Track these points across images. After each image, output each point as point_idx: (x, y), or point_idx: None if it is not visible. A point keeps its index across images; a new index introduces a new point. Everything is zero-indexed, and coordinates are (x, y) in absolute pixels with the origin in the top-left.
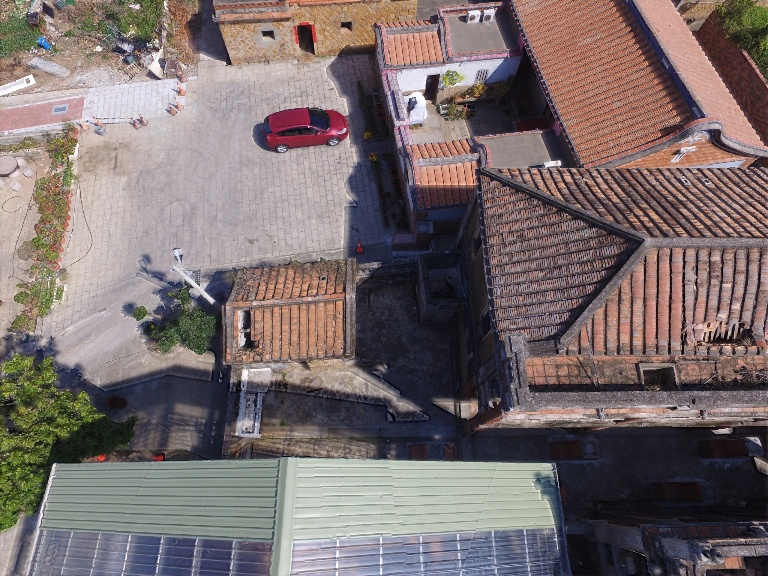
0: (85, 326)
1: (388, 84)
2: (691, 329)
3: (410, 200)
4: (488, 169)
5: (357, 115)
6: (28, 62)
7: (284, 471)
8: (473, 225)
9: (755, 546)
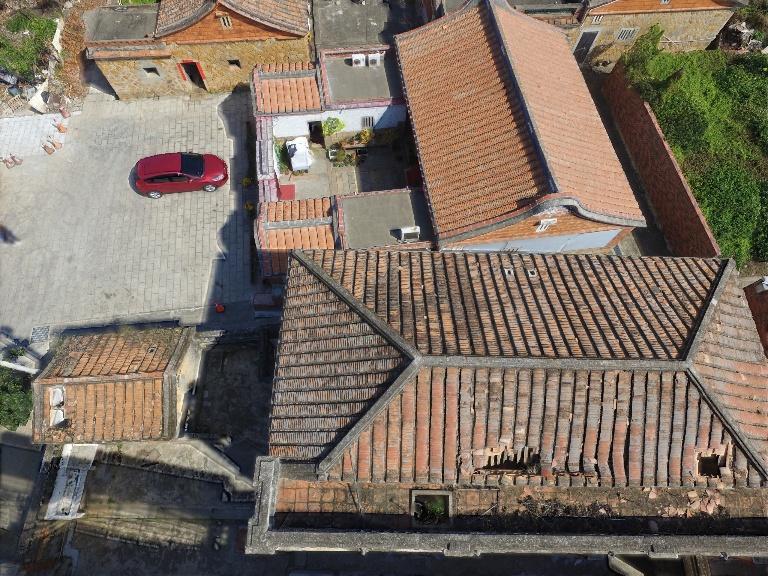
0: None
1: (261, 132)
2: (469, 455)
3: None
4: (298, 252)
5: (242, 158)
6: None
7: None
8: None
9: None
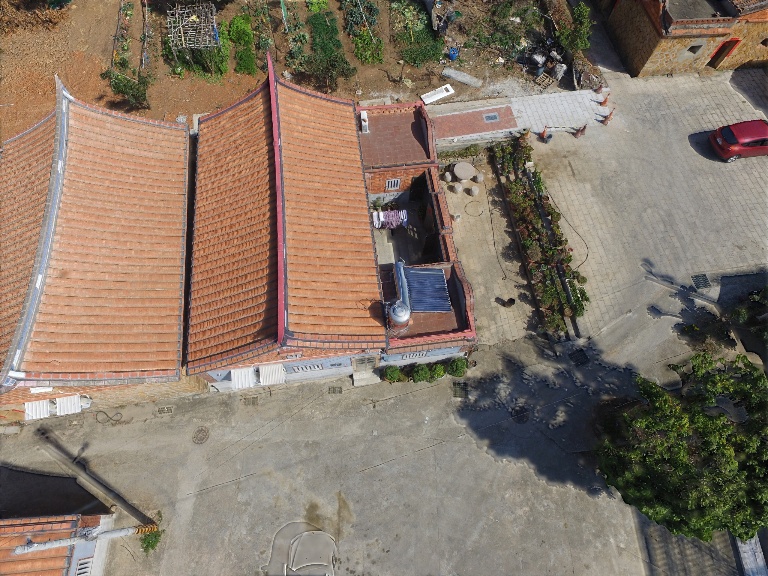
0: (618, 327)
1: None
2: None
3: None
4: None
5: None
6: (441, 72)
7: None
8: None
9: None
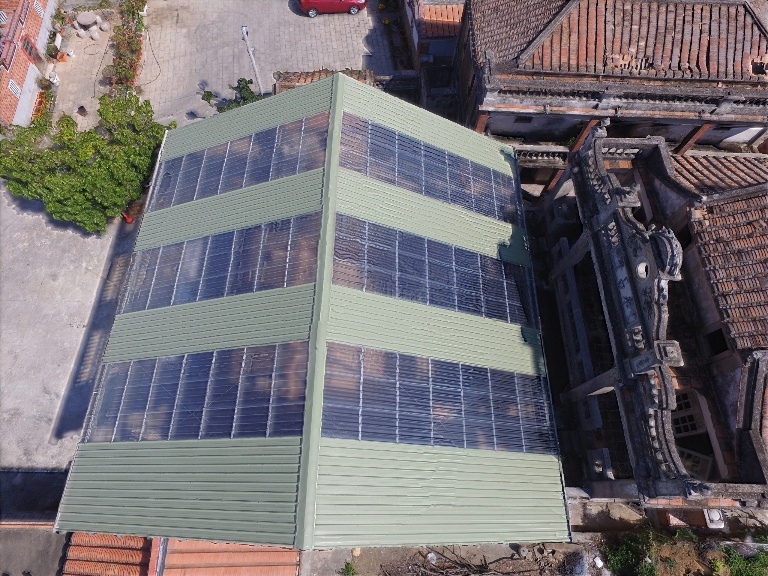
0: None
1: None
2: (611, 57)
3: (415, 40)
4: None
5: None
6: None
7: (337, 78)
8: (463, 33)
9: (635, 139)
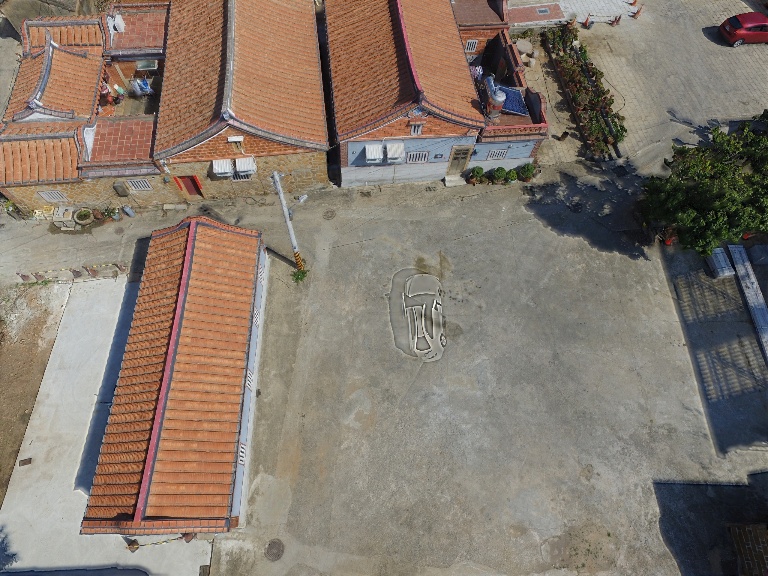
0: (650, 151)
1: None
2: None
3: None
4: None
5: None
6: None
7: None
8: None
9: None
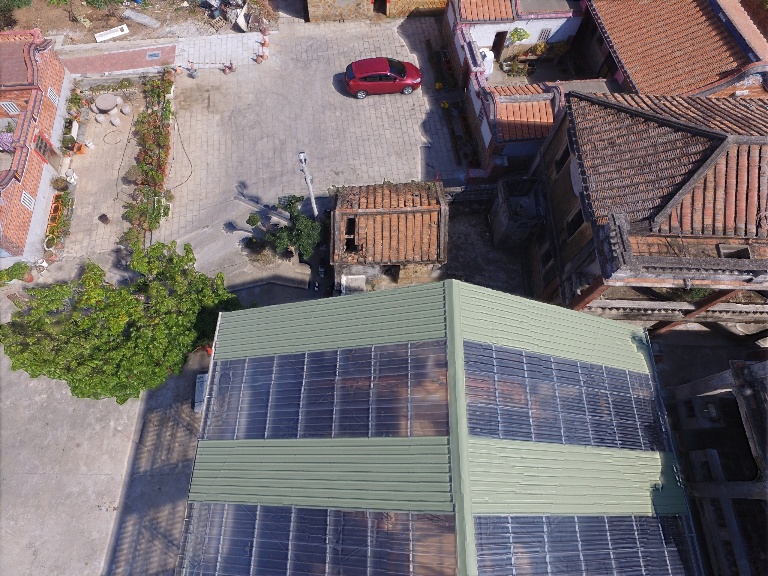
0: (190, 240)
1: (463, 37)
2: (764, 216)
3: (486, 137)
4: None
5: (427, 69)
6: (121, 13)
7: (450, 288)
8: (555, 148)
9: None
